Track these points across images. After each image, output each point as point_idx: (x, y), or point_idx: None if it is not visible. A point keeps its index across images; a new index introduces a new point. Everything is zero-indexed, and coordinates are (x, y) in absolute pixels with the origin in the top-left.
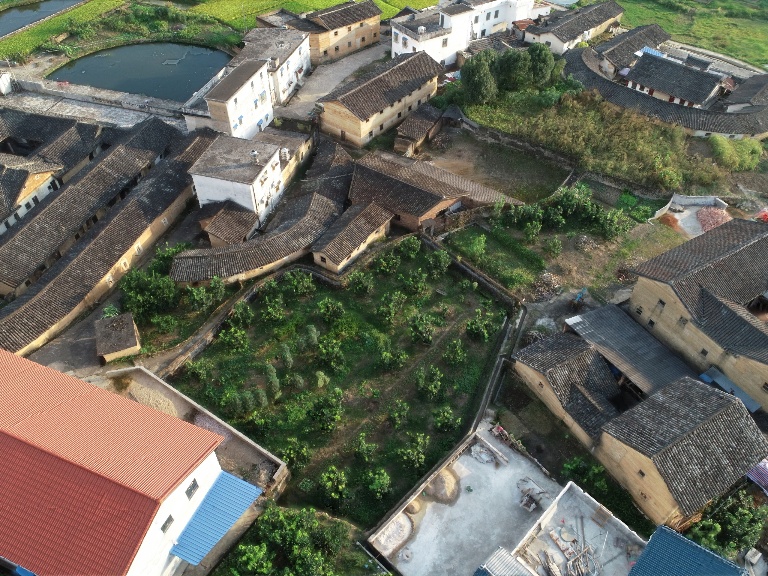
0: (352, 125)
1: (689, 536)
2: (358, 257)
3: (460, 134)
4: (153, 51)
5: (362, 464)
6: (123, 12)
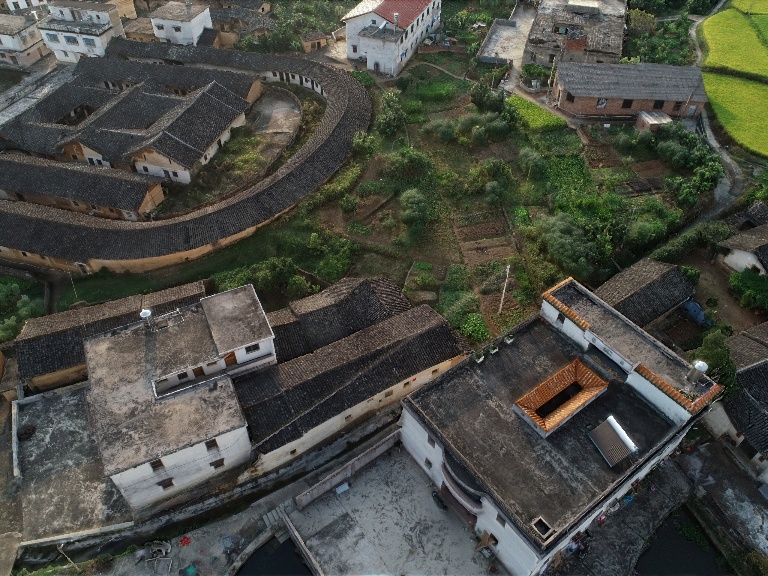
0: (128, 7)
1: None
2: None
3: None
4: None
5: None
6: None
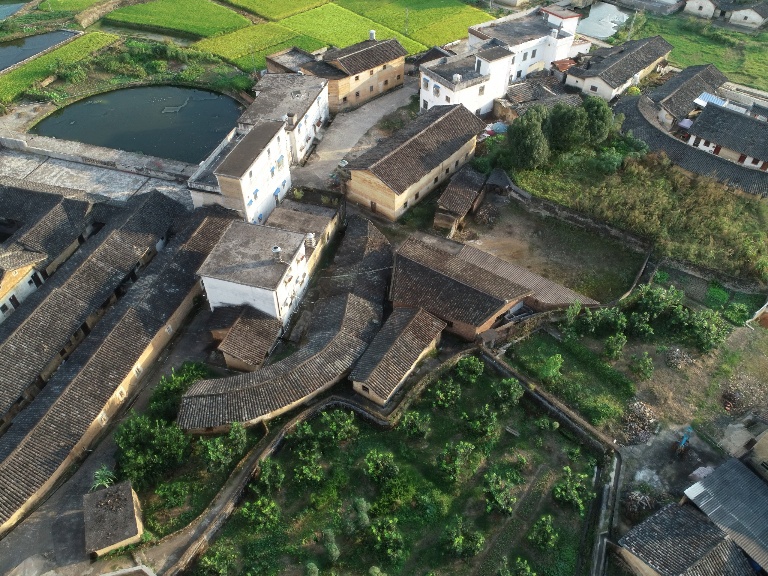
0: (385, 197)
1: None
2: (406, 380)
3: (508, 204)
4: (151, 96)
5: None
6: (117, 50)
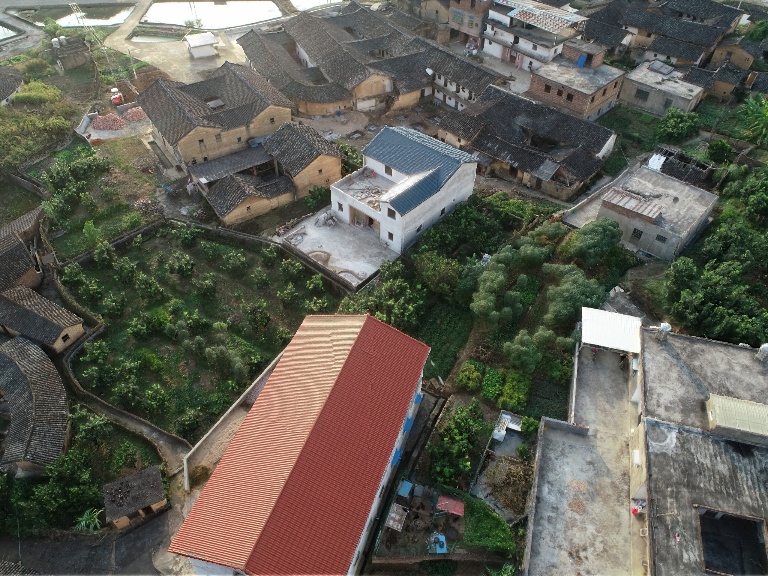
0: None
1: (350, 170)
2: None
3: None
4: None
5: (295, 305)
6: None
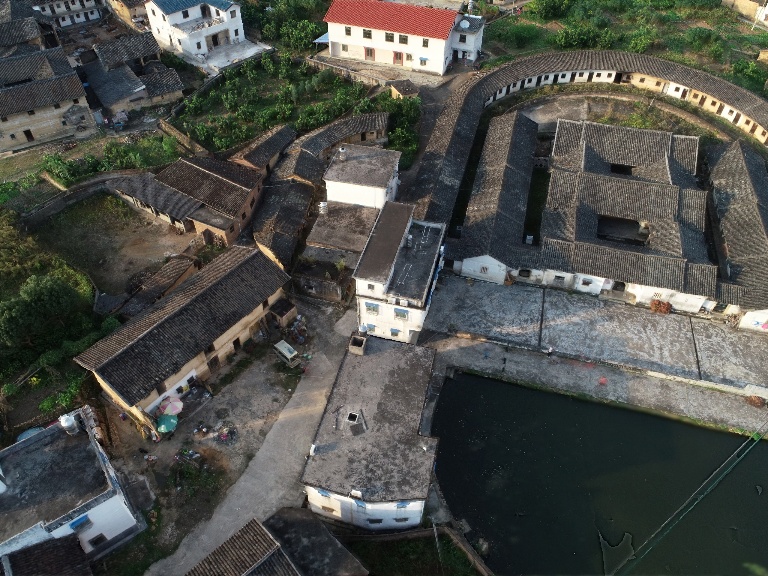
0: None
1: None
2: None
3: None
4: None
5: None
6: None
